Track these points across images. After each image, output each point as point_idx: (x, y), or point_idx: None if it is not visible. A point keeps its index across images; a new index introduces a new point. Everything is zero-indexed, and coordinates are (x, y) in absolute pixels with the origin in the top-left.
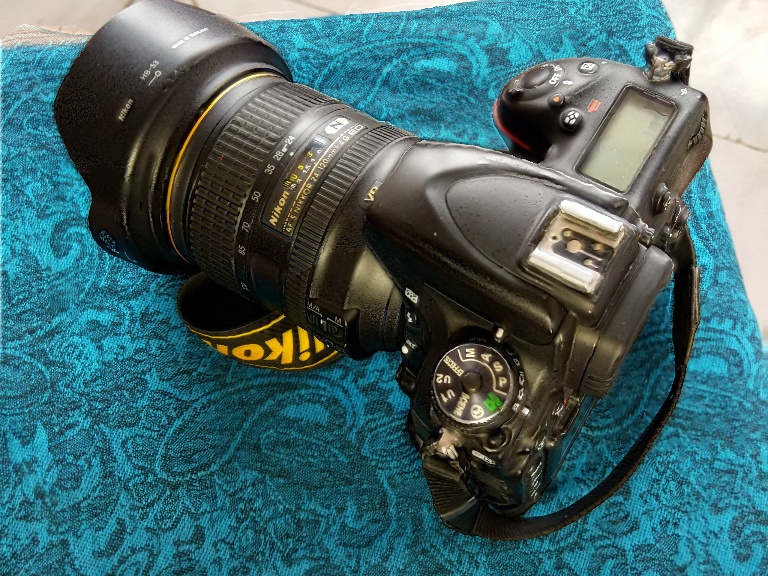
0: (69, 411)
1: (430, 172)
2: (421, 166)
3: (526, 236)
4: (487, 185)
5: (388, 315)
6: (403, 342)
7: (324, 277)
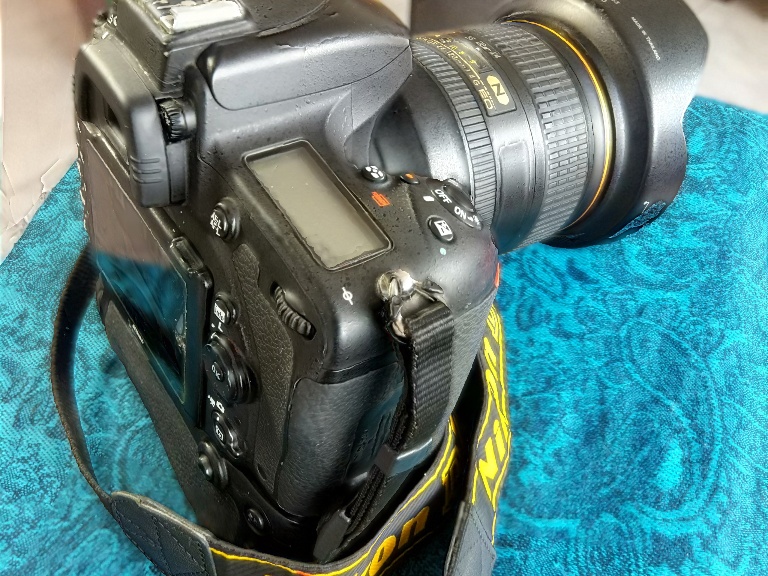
0: None
1: (356, 0)
2: None
3: None
4: (306, 2)
5: None
6: None
7: None
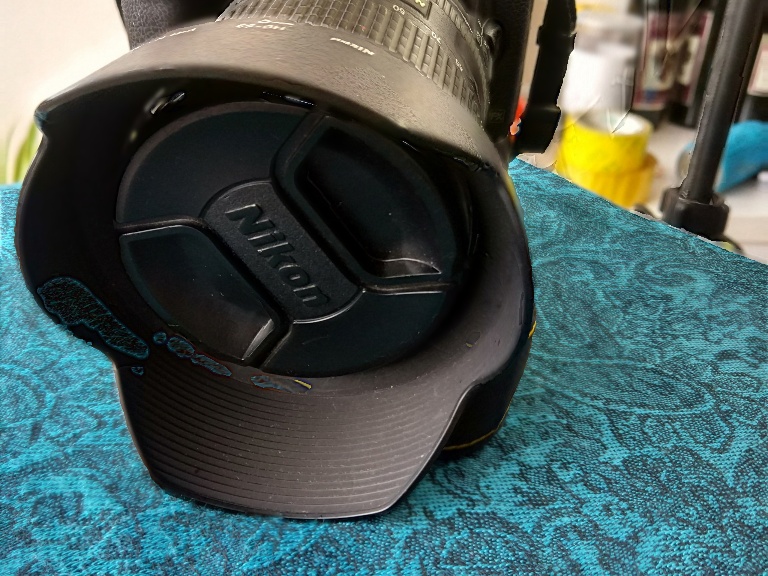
0: (759, 533)
1: None
2: None
3: None
4: None
5: None
6: None
7: None
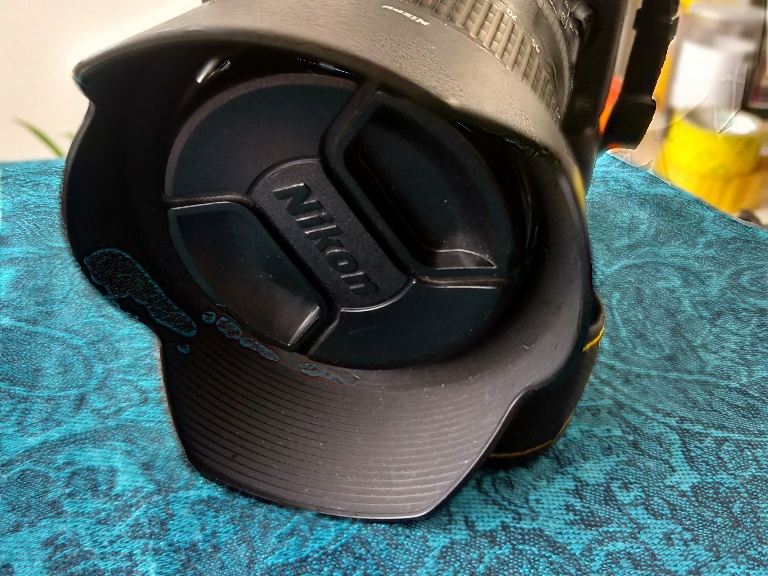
0: None
1: None
2: None
3: None
4: None
5: None
6: None
7: None
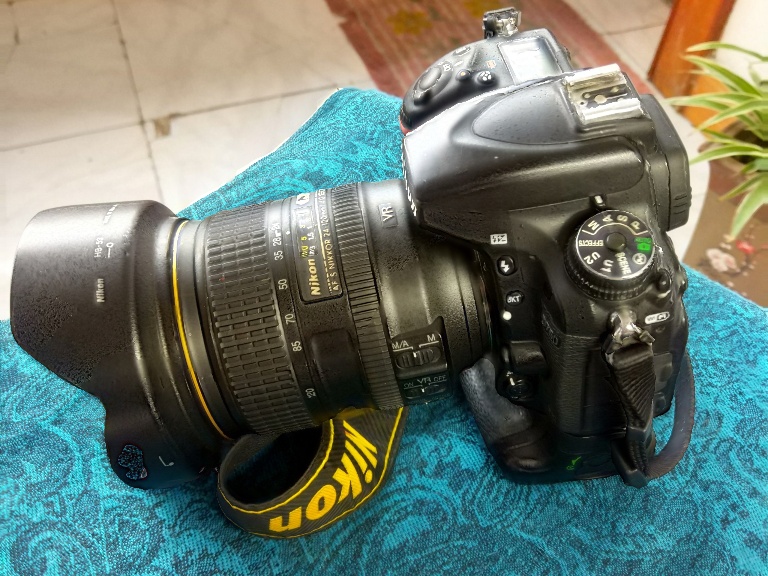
0: None
1: (445, 132)
2: (432, 136)
3: (564, 113)
4: (499, 108)
5: (466, 307)
6: (501, 311)
7: (395, 306)
